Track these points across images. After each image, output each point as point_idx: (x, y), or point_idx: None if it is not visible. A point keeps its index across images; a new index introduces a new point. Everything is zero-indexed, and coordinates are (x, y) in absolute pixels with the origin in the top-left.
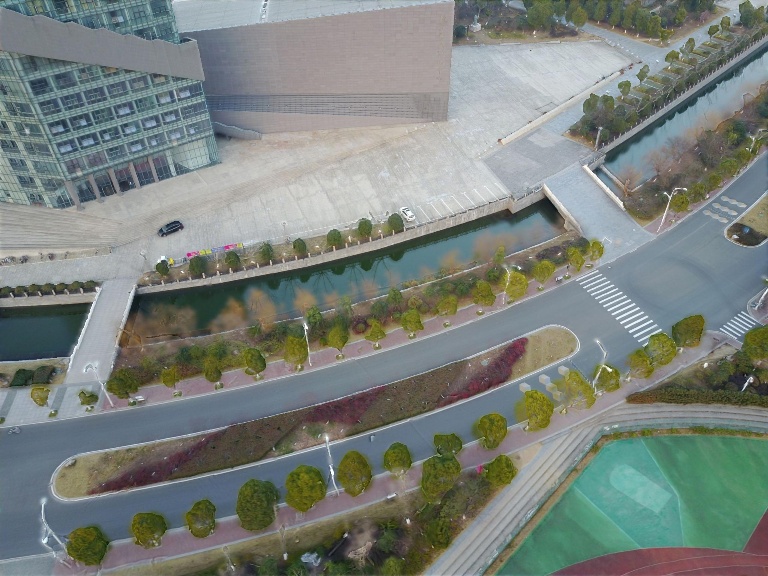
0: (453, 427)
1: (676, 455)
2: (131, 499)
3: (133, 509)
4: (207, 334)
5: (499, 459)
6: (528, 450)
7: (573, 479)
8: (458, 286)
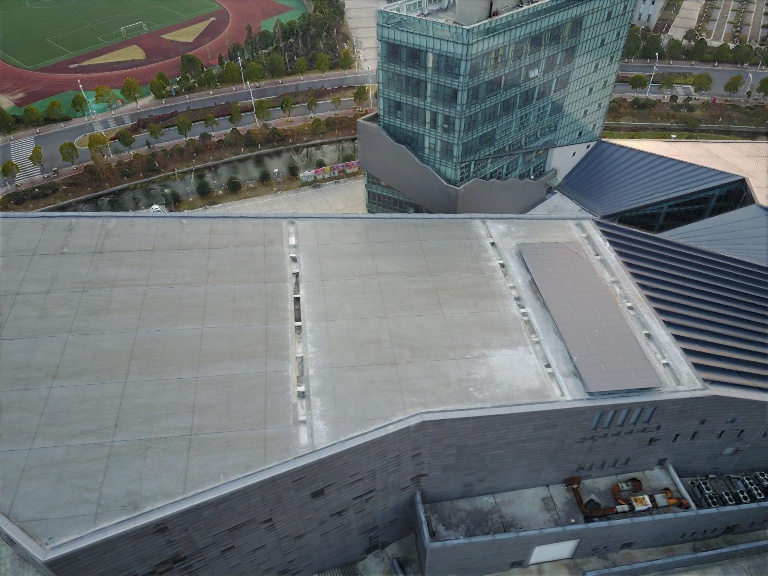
0: (179, 108)
1: (65, 112)
2: (341, 84)
3: (339, 83)
4: (331, 143)
5: (161, 72)
6: (143, 103)
7: (127, 103)
8: (141, 156)
